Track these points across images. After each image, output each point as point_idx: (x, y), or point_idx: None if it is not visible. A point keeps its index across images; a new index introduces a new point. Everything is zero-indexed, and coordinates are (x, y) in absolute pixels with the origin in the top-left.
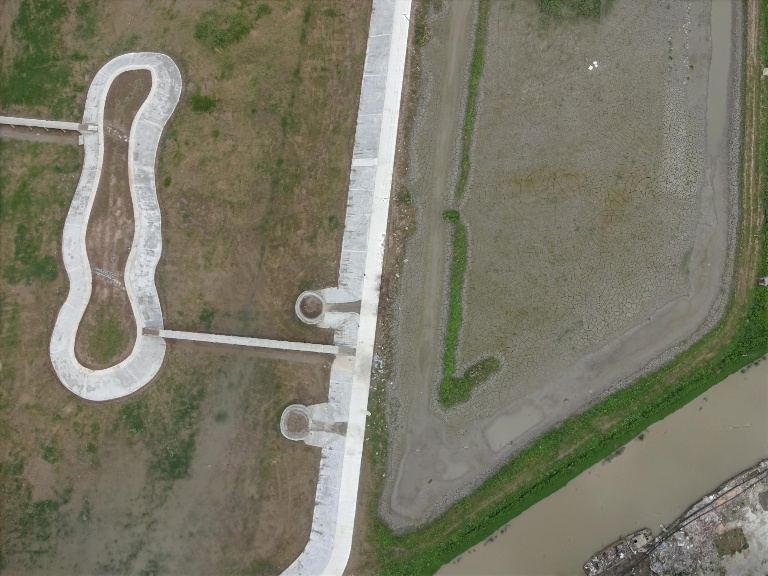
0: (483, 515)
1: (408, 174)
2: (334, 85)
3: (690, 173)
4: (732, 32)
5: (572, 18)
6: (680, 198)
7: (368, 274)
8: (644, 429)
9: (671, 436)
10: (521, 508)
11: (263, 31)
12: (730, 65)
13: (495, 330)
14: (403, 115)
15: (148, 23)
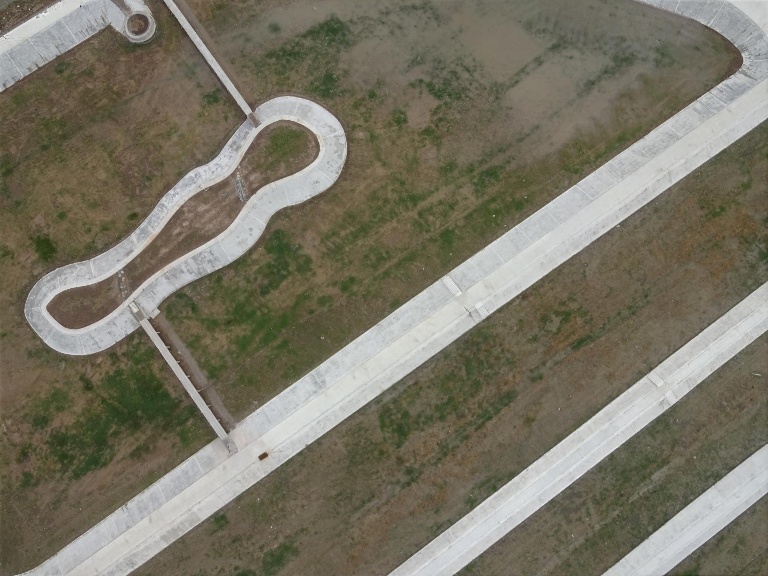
0: None
1: None
2: None
3: None
4: None
5: None
6: None
7: (78, 4)
8: None
9: None
10: None
11: None
12: None
13: None
14: None
15: (8, 356)
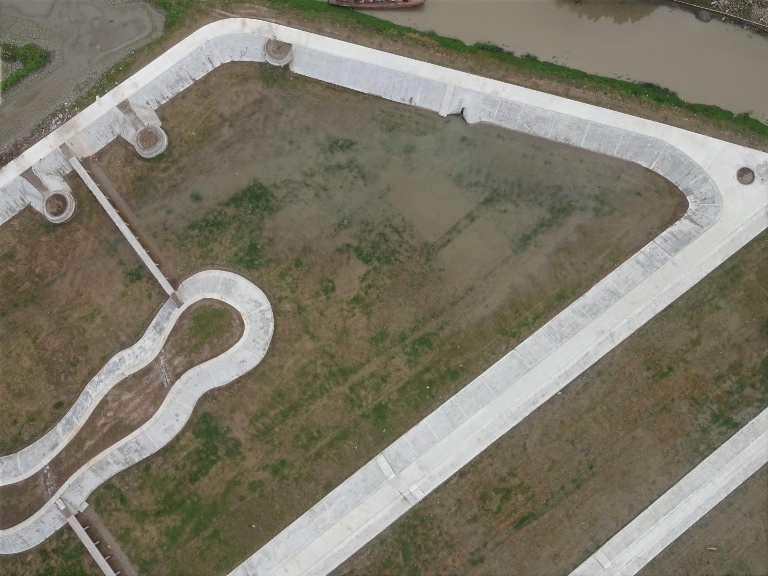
0: None
1: None
2: None
3: None
4: None
5: None
6: None
7: None
8: None
9: None
10: None
11: None
12: None
13: None
14: None
15: None
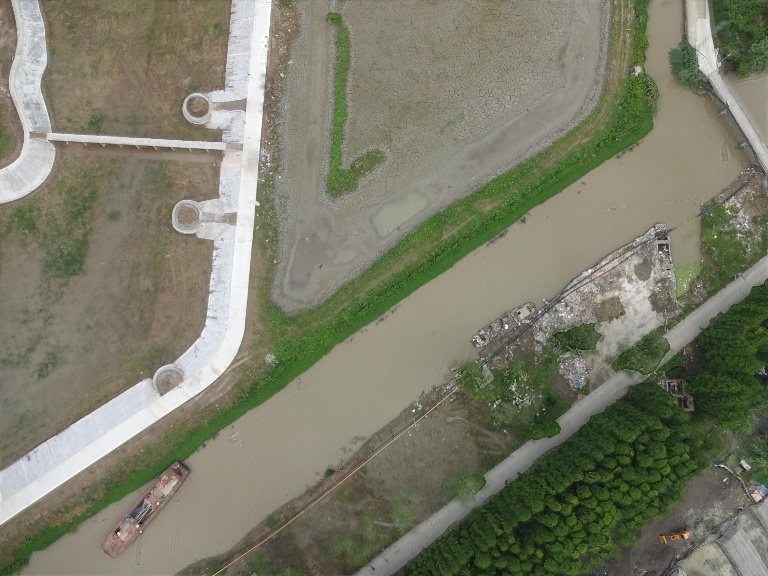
0: (372, 294)
1: None
2: None
3: None
4: None
5: None
6: None
7: (252, 74)
8: (526, 212)
9: (553, 220)
10: (410, 288)
11: None
12: None
13: (379, 124)
14: None
15: None
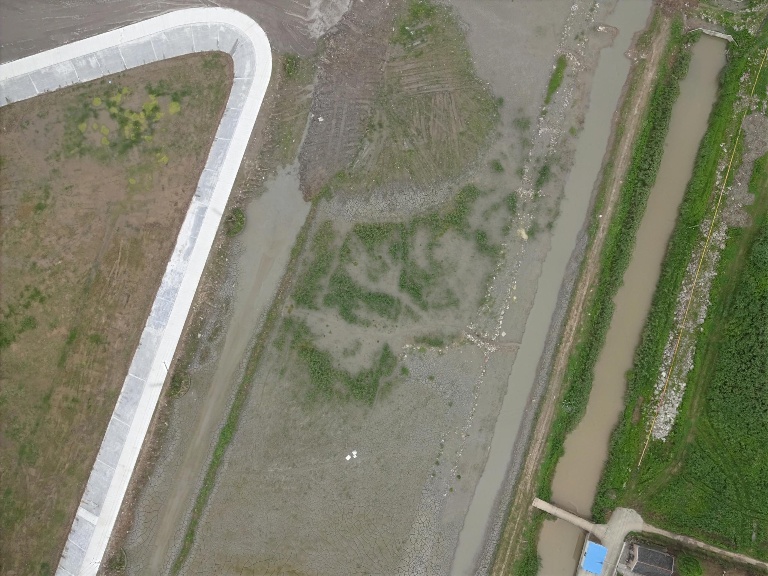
0: None
1: (128, 537)
2: (81, 420)
3: None
4: (514, 446)
5: (342, 398)
6: None
7: None
8: None
9: None
10: None
11: (24, 346)
12: (502, 483)
13: None
14: (136, 475)
15: None
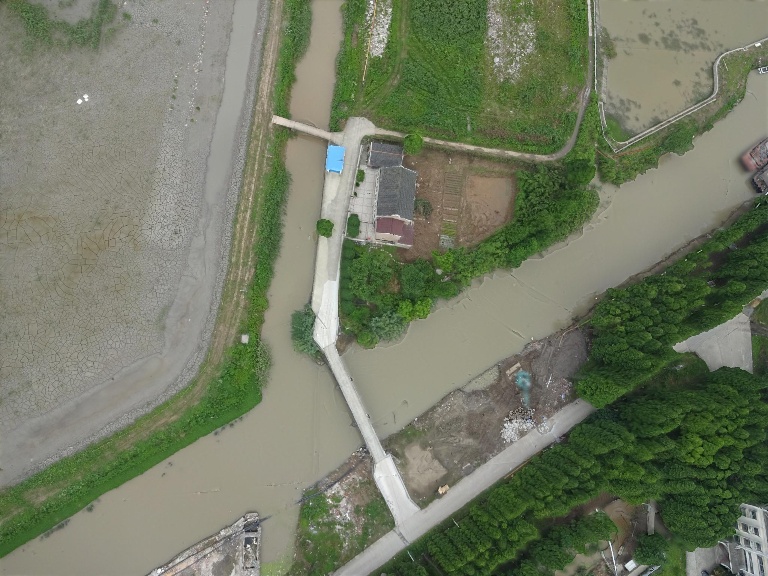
0: None
1: None
2: None
3: (180, 222)
4: (247, 75)
5: (63, 45)
6: (165, 248)
7: None
8: (94, 499)
9: (131, 504)
10: None
11: None
12: (241, 109)
13: None
14: None
15: None
